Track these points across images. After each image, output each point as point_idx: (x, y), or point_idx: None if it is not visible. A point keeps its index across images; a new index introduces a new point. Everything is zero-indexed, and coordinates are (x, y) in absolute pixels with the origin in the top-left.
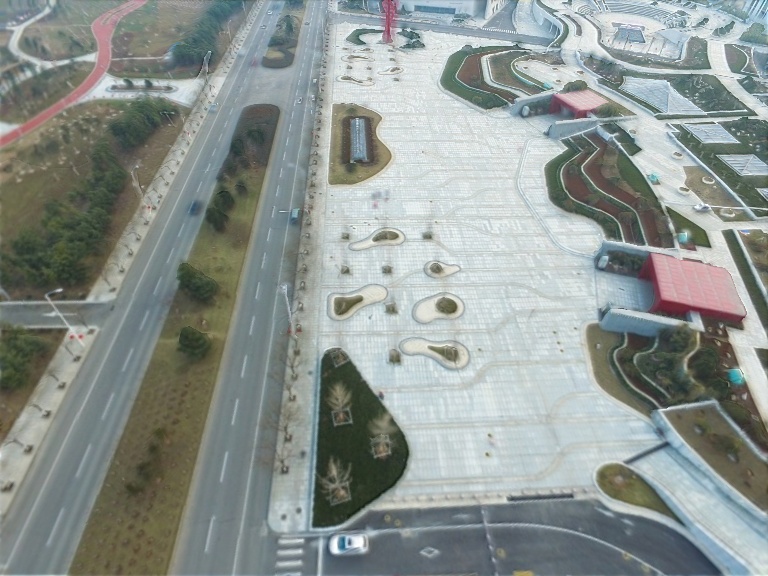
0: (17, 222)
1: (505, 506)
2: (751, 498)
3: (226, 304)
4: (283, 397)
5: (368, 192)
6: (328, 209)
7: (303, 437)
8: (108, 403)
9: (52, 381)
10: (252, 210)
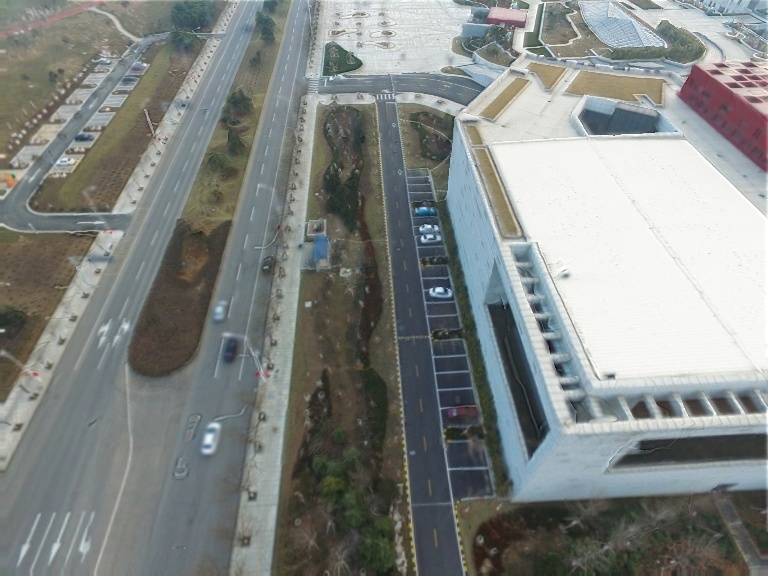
0: (168, 7)
1: (400, 75)
2: (497, 63)
3: (279, 32)
4: (309, 54)
5: (351, 1)
6: (328, 7)
7: (318, 61)
8: (233, 56)
9: (208, 48)
10: (287, 7)
